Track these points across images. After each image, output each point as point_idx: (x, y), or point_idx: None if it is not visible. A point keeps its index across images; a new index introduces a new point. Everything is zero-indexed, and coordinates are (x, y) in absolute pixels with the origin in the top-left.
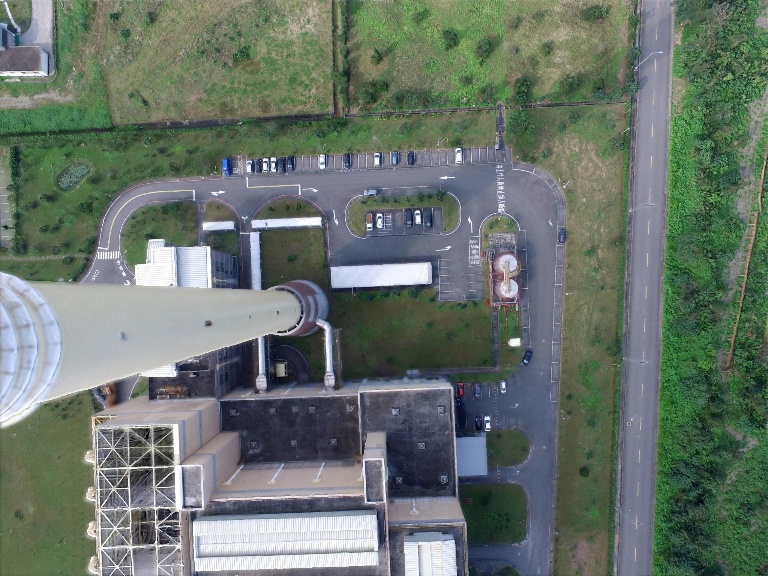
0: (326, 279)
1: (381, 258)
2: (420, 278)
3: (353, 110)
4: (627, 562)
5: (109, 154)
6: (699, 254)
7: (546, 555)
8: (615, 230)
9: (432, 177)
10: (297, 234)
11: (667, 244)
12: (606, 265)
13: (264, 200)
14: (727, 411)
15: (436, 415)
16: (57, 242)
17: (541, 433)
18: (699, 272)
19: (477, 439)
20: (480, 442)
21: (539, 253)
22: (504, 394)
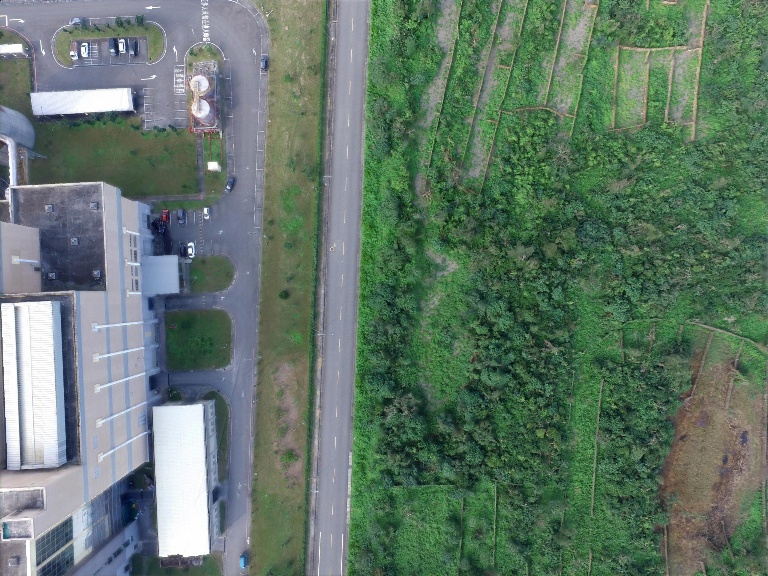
0: None
1: (87, 87)
2: (120, 104)
3: None
4: (330, 385)
5: None
6: (395, 79)
7: (250, 379)
8: (317, 58)
9: (138, 7)
10: (3, 64)
11: (368, 71)
12: (308, 92)
13: None
14: (426, 235)
15: (90, 212)
16: None
17: (245, 259)
18: (393, 95)
19: (169, 258)
20: (172, 261)
21: (243, 81)
22: (208, 221)
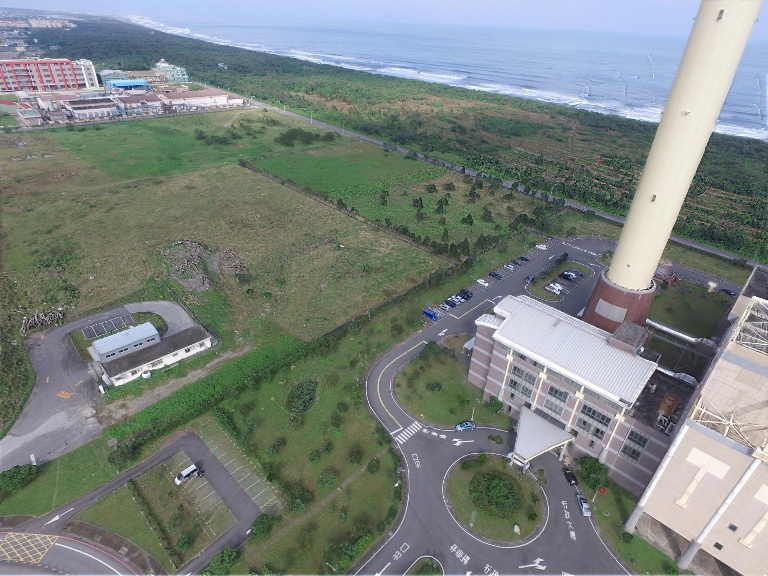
0: None
1: None
2: None
3: (463, 259)
4: None
5: (325, 360)
6: None
7: None
8: None
9: None
10: None
11: None
12: None
13: None
14: None
15: None
16: (340, 460)
17: None
18: (695, 227)
19: None
20: None
21: None
22: None
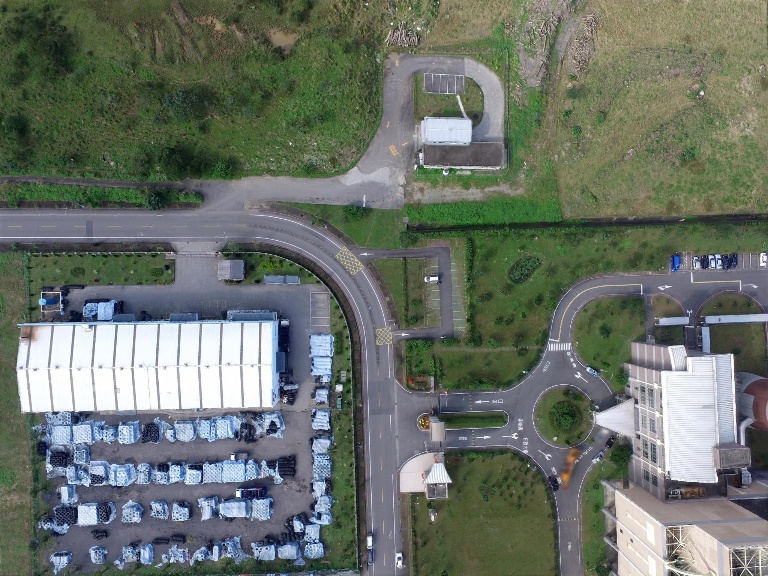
0: (766, 371)
1: None
2: None
3: None
4: None
5: (561, 248)
6: None
7: None
8: None
9: None
10: (739, 328)
11: None
12: None
13: (708, 295)
14: None
15: None
16: (510, 334)
17: None
18: None
19: None
20: None
21: None
22: None
